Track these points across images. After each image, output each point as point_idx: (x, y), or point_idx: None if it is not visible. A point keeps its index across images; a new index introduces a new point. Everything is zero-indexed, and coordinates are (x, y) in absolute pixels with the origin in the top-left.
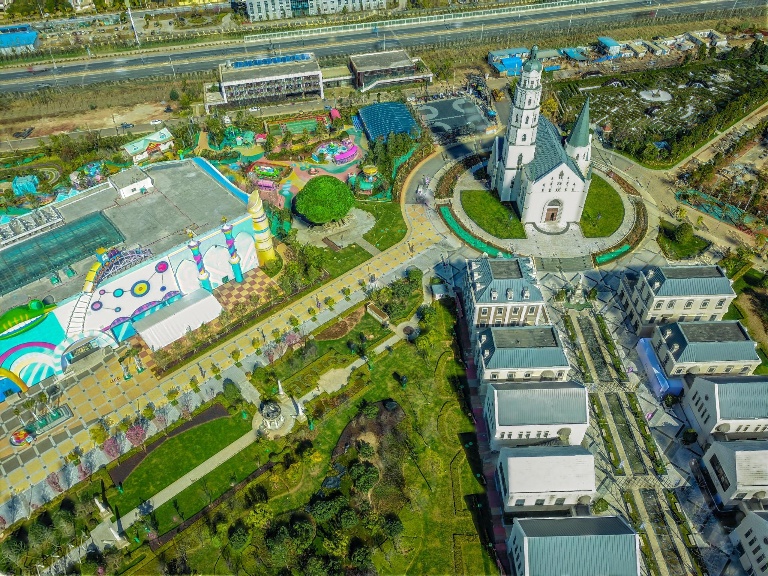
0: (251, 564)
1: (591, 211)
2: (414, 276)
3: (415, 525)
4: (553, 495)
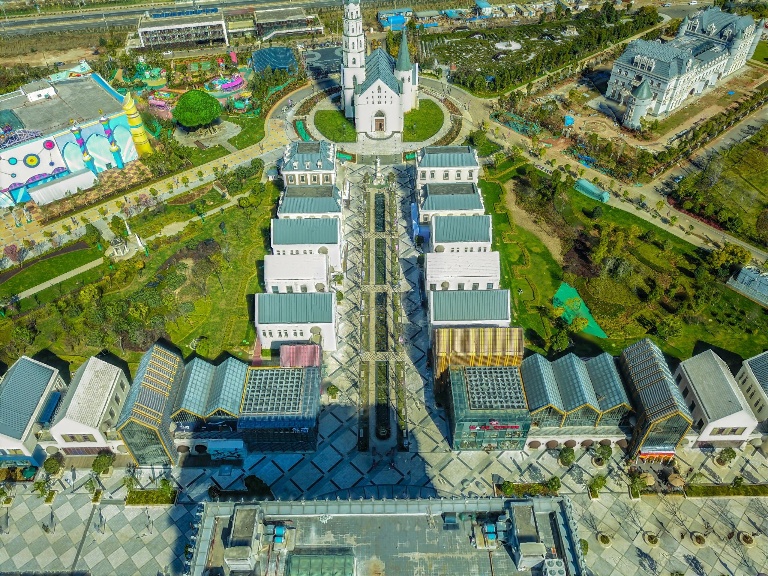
0: (80, 327)
1: (416, 125)
2: (254, 163)
3: (204, 309)
4: (296, 282)
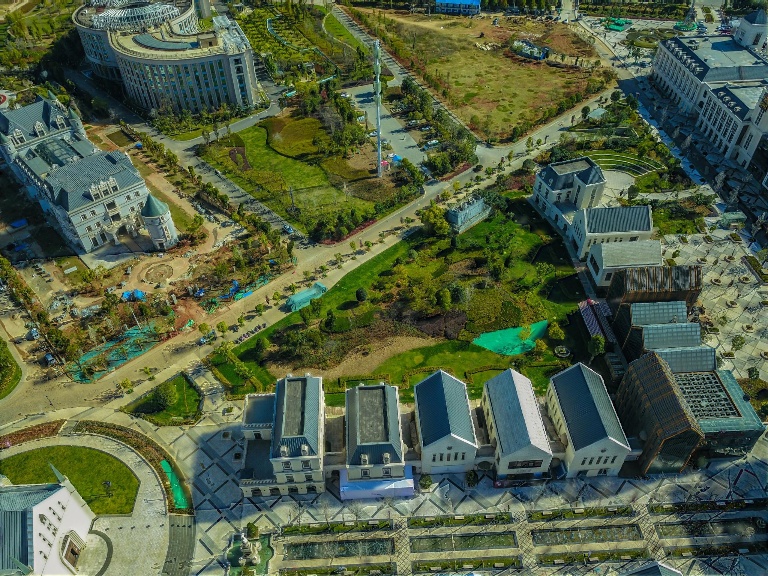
0: None
1: None
2: None
3: None
4: None
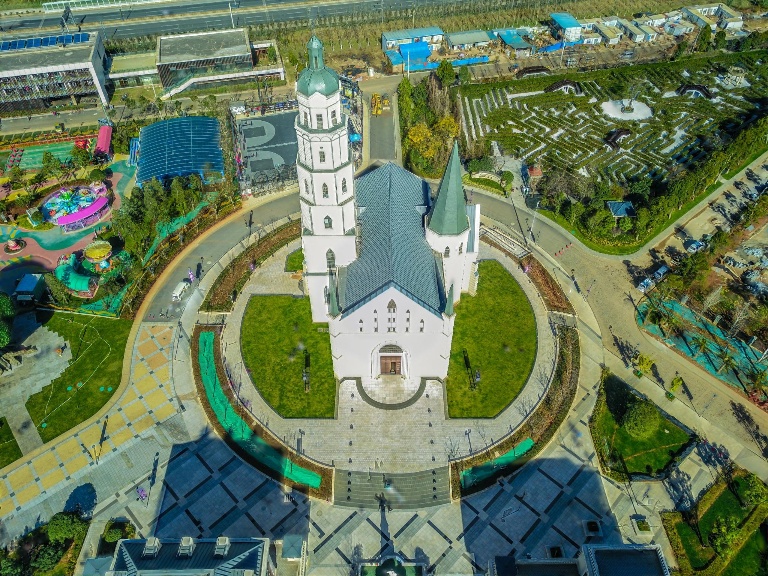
0: None
1: (474, 350)
2: (54, 534)
3: None
4: None
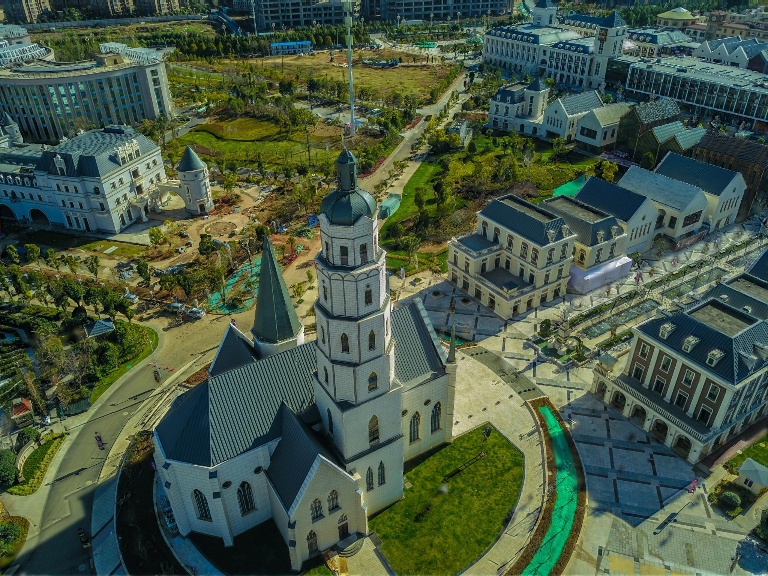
0: None
1: None
2: None
3: None
4: None
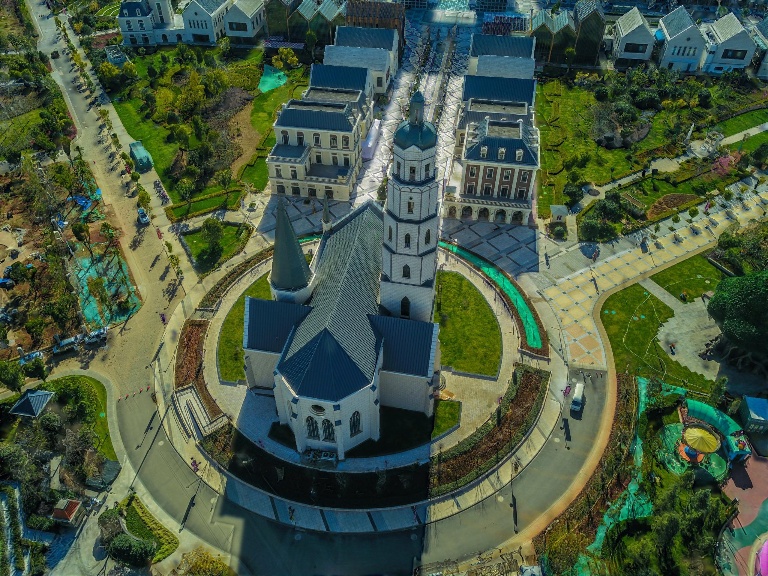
0: None
1: None
2: None
3: (586, 97)
4: None
